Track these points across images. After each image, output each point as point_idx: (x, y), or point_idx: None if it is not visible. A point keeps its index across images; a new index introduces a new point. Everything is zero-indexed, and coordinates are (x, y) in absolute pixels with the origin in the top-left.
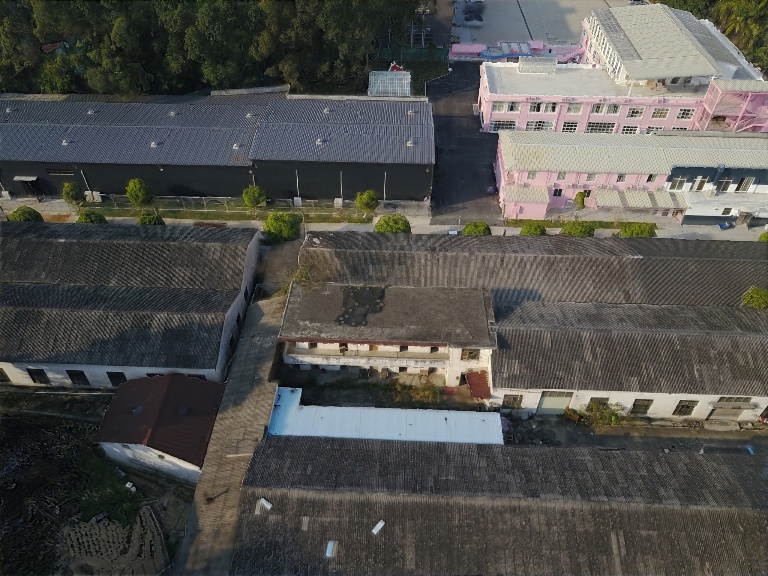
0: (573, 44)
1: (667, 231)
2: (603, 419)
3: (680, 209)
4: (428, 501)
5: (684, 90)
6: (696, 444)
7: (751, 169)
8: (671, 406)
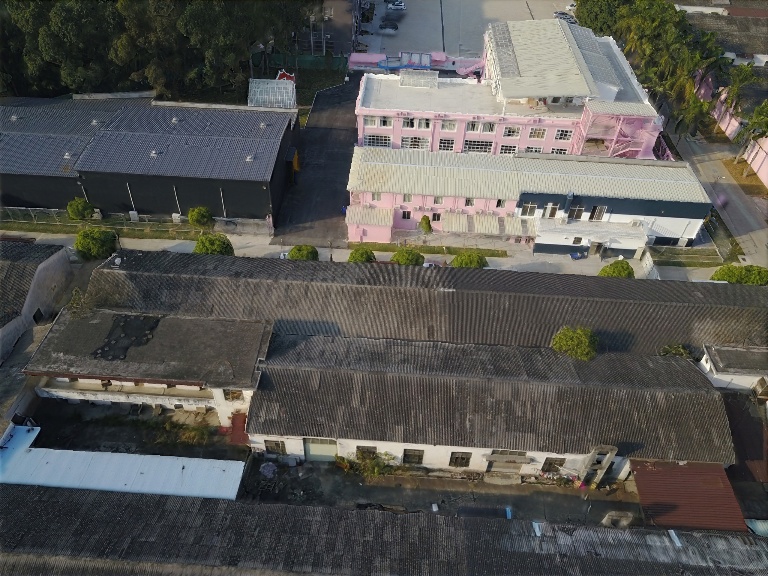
0: (477, 57)
1: (516, 259)
2: (366, 470)
3: (530, 237)
4: (111, 567)
5: (564, 110)
6: (468, 499)
7: (601, 197)
8: (444, 457)
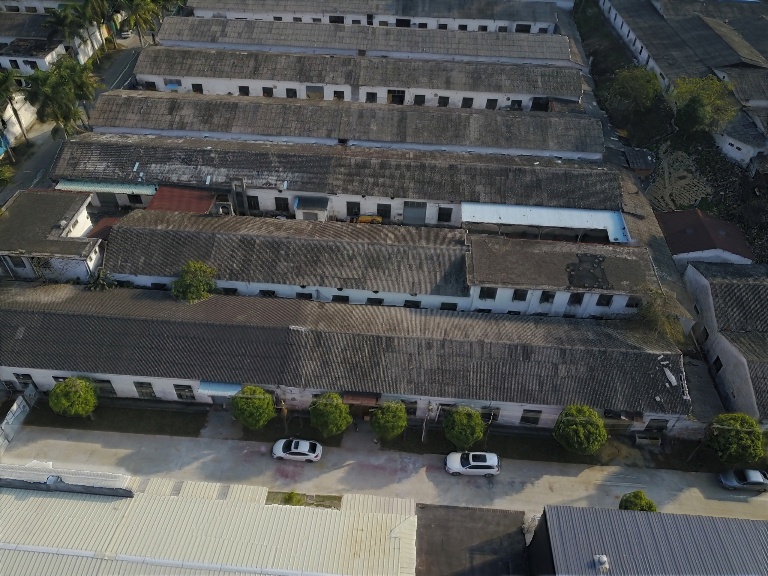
0: None
1: None
2: None
3: None
4: None
5: None
6: None
7: (3, 479)
8: None
